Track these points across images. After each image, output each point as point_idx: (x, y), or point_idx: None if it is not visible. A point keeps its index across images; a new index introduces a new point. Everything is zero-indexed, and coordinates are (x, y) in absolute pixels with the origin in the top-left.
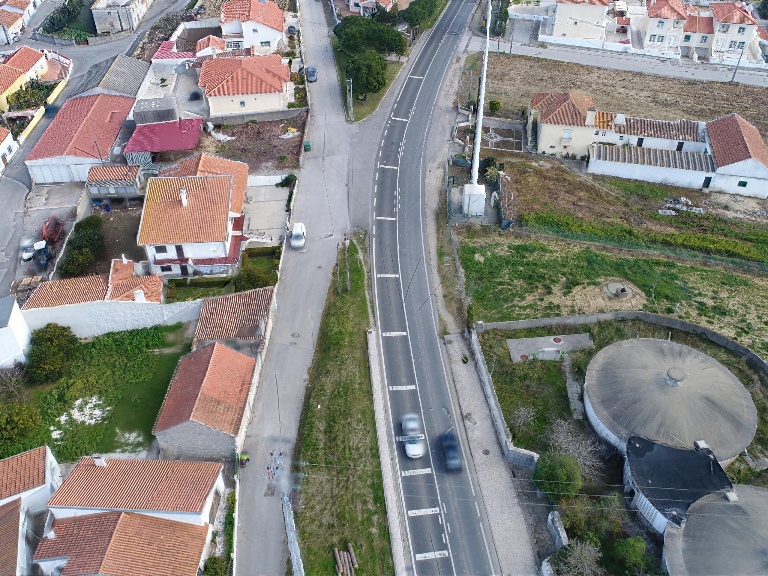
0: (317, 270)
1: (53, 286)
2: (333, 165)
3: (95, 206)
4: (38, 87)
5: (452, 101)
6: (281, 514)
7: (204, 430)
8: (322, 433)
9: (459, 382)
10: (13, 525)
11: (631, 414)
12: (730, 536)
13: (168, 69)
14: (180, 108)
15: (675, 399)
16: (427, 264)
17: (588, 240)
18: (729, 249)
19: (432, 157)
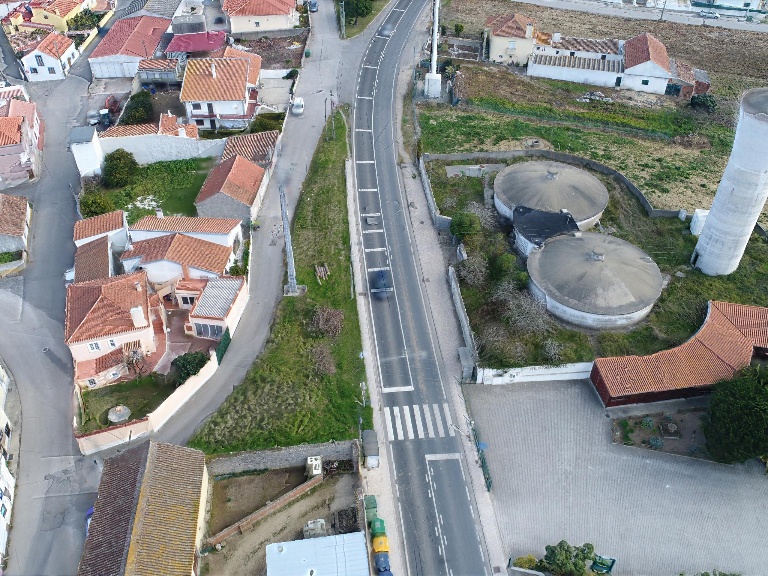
0: (311, 128)
1: (119, 128)
2: (327, 66)
3: (144, 89)
4: (90, 16)
5: (426, 27)
6: (281, 254)
7: (229, 201)
8: (310, 212)
9: (408, 188)
10: (104, 248)
11: (521, 195)
12: (569, 248)
13: (197, 2)
14: (207, 29)
15: (551, 186)
16: (394, 125)
17: (518, 114)
18: (624, 122)
19: (405, 62)
